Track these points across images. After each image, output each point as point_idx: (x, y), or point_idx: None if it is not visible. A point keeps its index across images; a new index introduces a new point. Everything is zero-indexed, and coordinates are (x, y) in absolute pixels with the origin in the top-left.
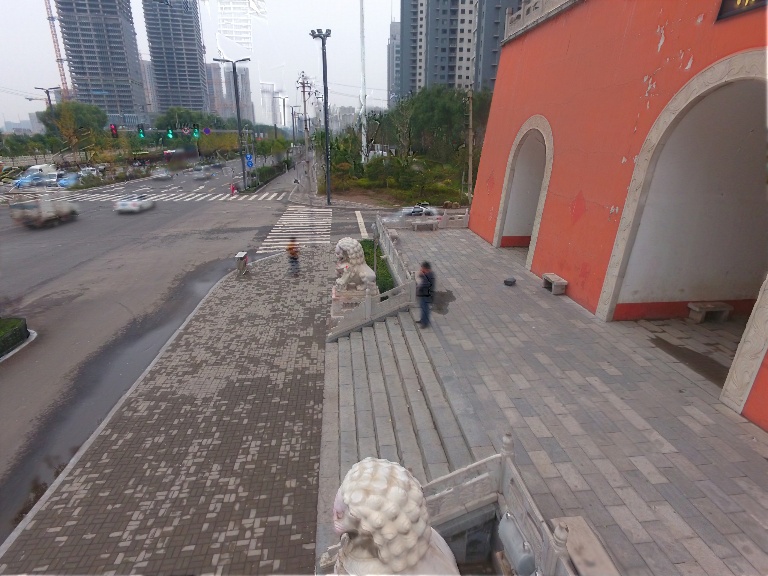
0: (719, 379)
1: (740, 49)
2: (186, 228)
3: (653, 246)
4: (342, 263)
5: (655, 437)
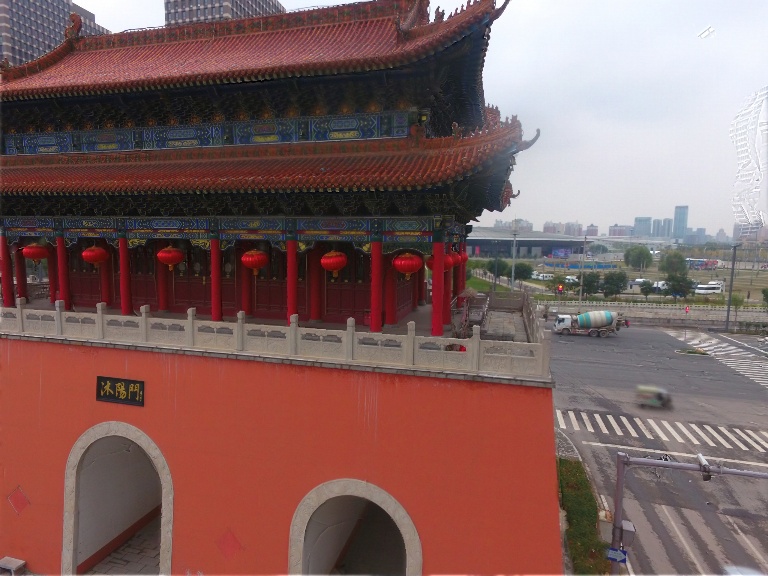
0: None
1: None
2: (610, 393)
3: None
4: None
5: None
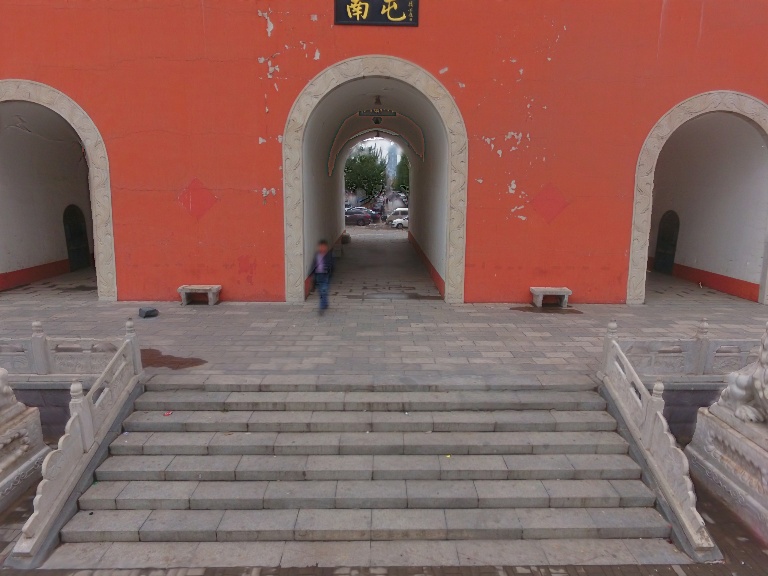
0: (418, 297)
1: (368, 53)
2: None
3: (306, 222)
4: None
5: (499, 325)
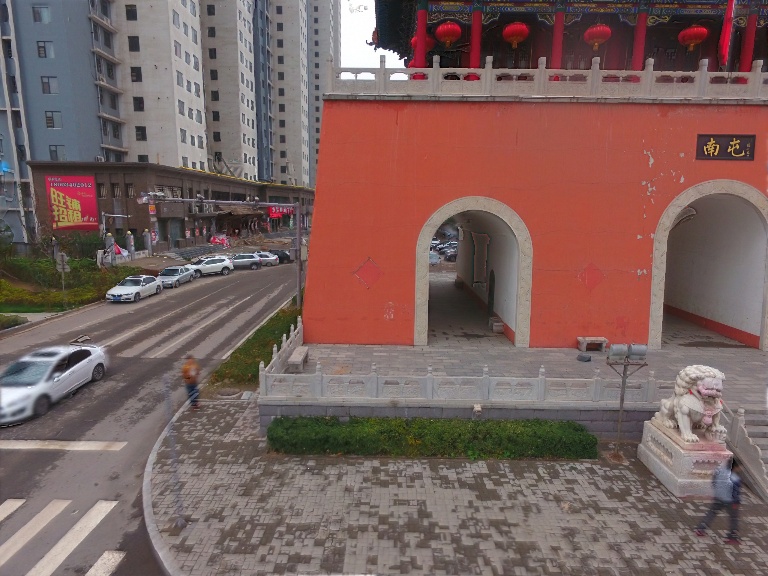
0: None
1: (717, 178)
2: None
3: None
4: (716, 402)
5: None
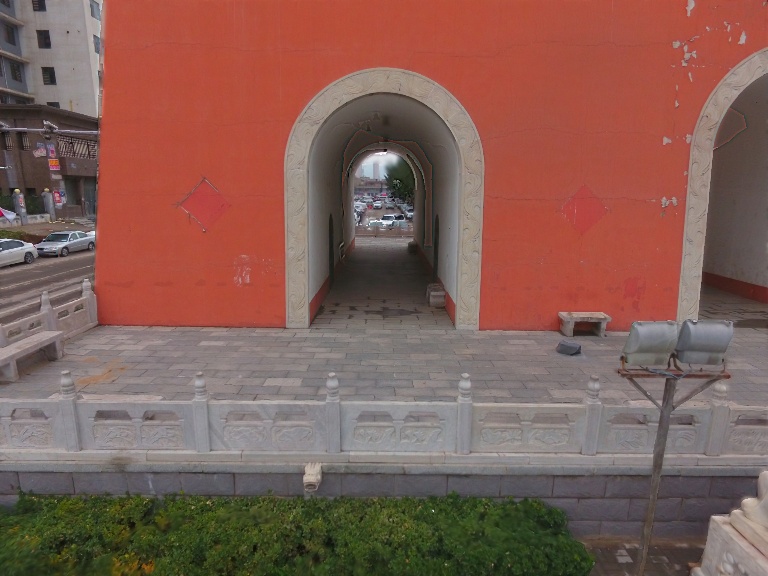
0: None
1: None
2: None
3: None
4: None
5: None
